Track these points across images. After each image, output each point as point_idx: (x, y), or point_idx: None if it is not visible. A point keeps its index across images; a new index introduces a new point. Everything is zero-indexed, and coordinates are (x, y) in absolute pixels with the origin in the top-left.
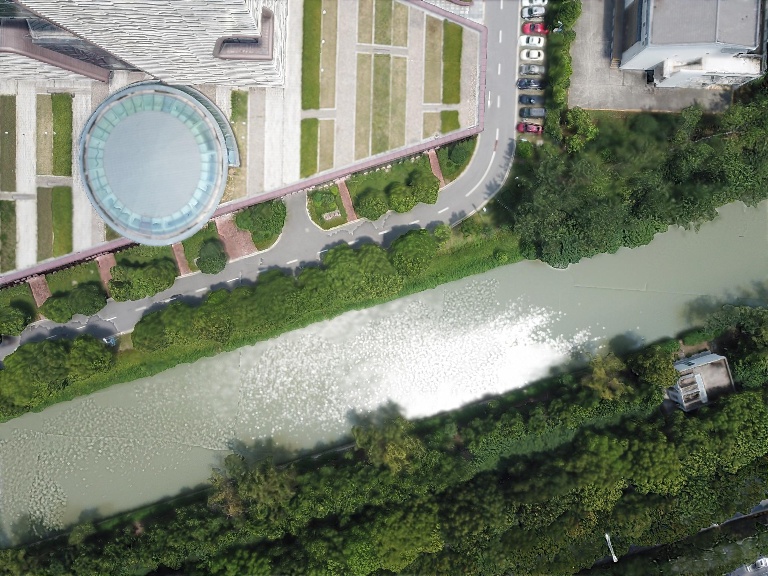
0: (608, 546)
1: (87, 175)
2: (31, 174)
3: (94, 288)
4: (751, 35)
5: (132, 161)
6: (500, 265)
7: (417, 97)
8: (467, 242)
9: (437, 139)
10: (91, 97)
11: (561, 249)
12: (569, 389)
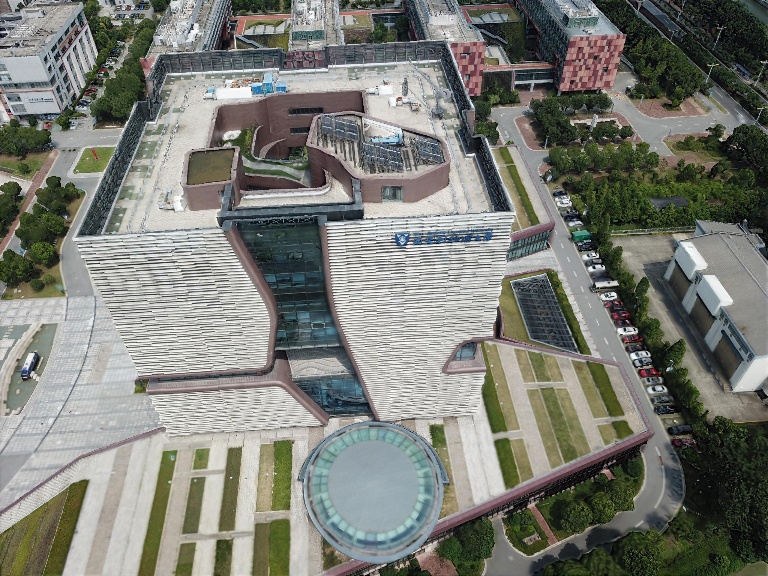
0: None
1: (311, 500)
2: (250, 512)
3: None
4: None
5: (355, 482)
6: (723, 575)
7: (587, 415)
8: (678, 553)
9: (618, 444)
10: (308, 442)
11: None
12: None
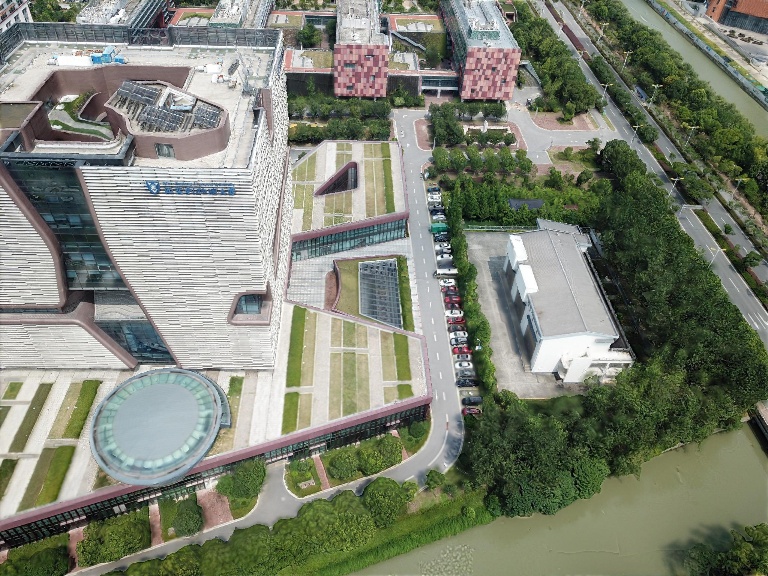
0: None
1: (95, 430)
2: (42, 438)
3: (60, 551)
4: (611, 330)
5: (139, 417)
6: (470, 525)
7: (378, 378)
8: (435, 504)
9: (396, 404)
10: (115, 383)
11: (520, 490)
12: None
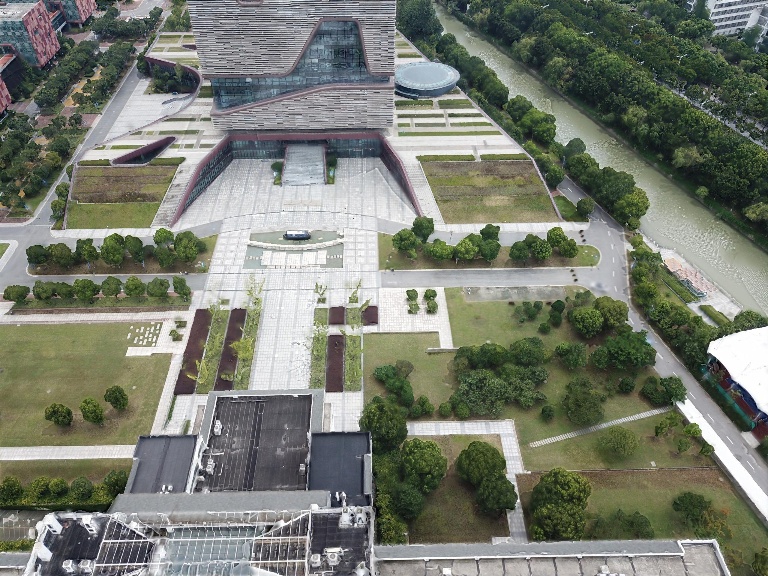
0: (544, 8)
1: None
2: None
3: None
4: None
5: None
6: None
7: None
8: None
9: None
10: (395, 98)
11: None
12: (489, 26)
